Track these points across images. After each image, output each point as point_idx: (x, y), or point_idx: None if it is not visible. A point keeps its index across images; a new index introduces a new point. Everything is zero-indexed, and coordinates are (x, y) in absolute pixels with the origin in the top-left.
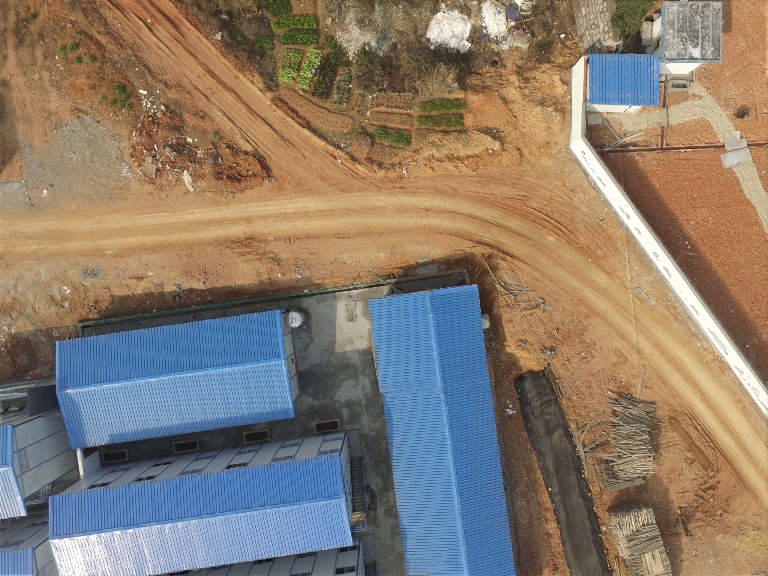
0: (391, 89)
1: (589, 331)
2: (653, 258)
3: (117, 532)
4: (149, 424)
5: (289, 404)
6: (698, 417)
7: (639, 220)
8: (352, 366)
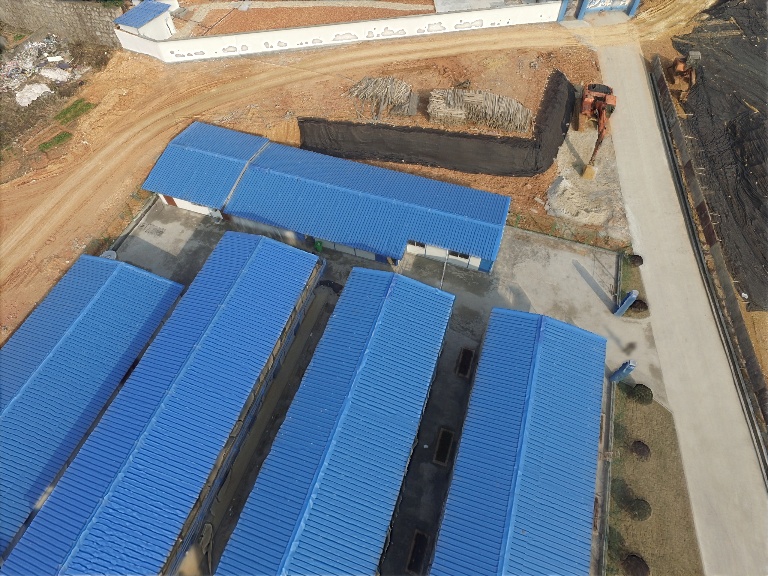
0: (24, 129)
1: (292, 92)
2: (270, 50)
3: (107, 496)
4: (59, 437)
5: (168, 284)
6: (391, 62)
7: (232, 37)
8: (199, 249)
